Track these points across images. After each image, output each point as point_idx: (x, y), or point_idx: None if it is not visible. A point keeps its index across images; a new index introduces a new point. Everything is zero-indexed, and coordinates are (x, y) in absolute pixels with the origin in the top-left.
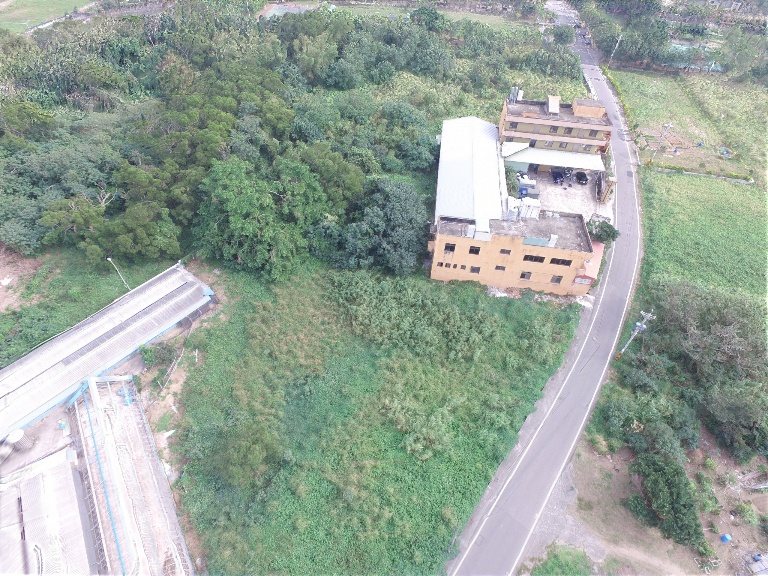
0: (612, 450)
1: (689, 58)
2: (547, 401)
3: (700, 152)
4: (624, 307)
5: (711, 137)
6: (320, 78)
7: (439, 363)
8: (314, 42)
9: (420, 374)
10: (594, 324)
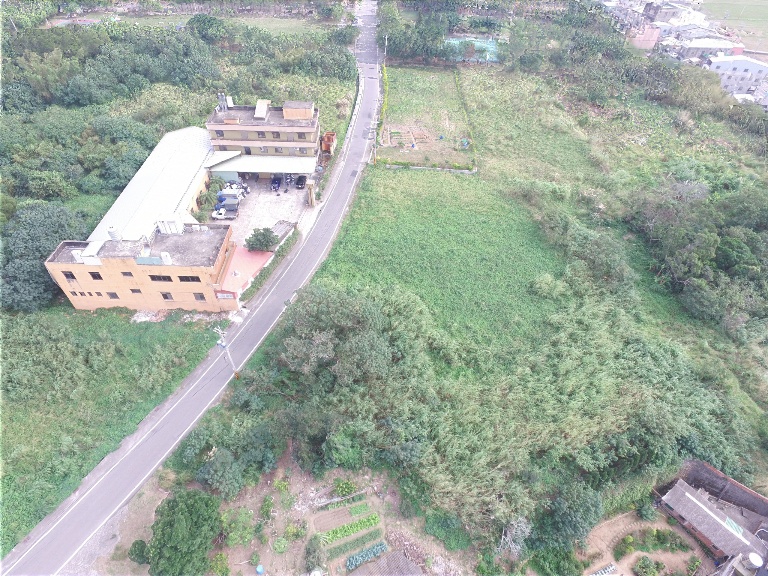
0: (180, 484)
1: (460, 51)
2: (137, 436)
3: (439, 145)
4: (276, 318)
5: (459, 129)
6: (56, 96)
7: (35, 407)
8: (47, 58)
9: (3, 423)
10: (234, 341)
